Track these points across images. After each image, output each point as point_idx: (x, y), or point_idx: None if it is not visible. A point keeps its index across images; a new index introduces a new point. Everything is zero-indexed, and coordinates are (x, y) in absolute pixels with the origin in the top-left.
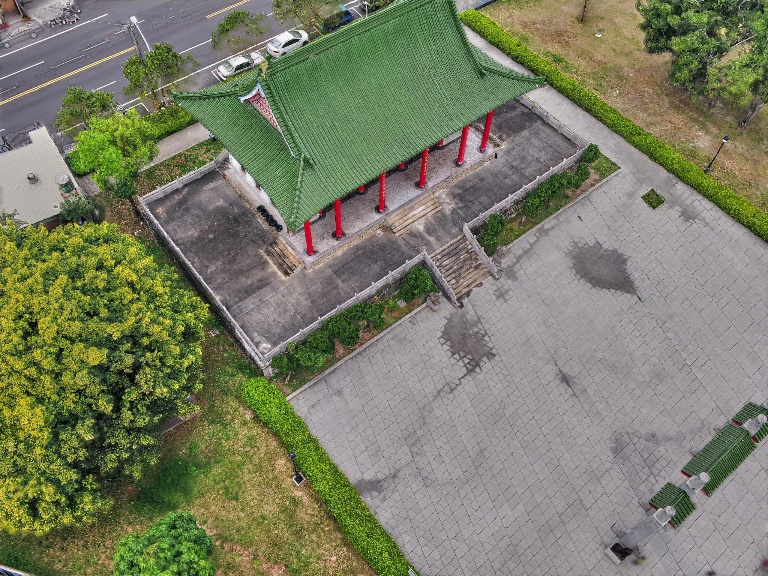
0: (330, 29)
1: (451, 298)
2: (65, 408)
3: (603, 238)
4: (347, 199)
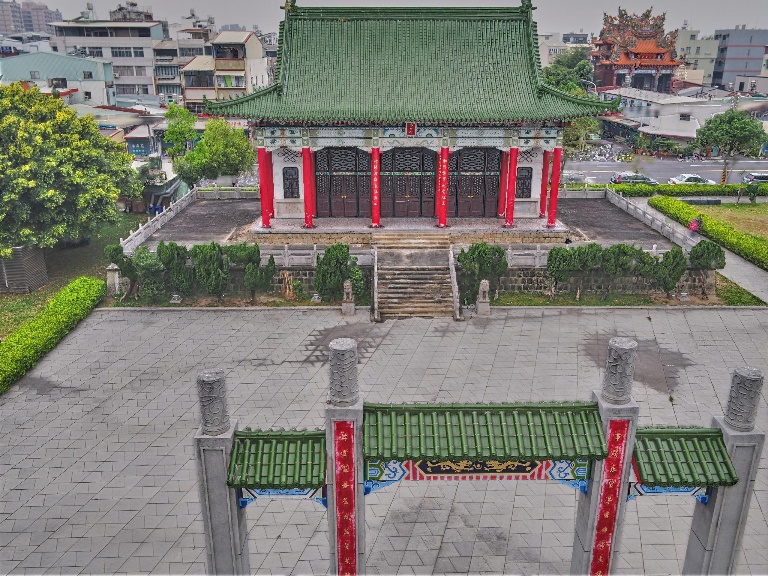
0: None
1: (374, 310)
2: None
3: (669, 340)
4: (353, 217)
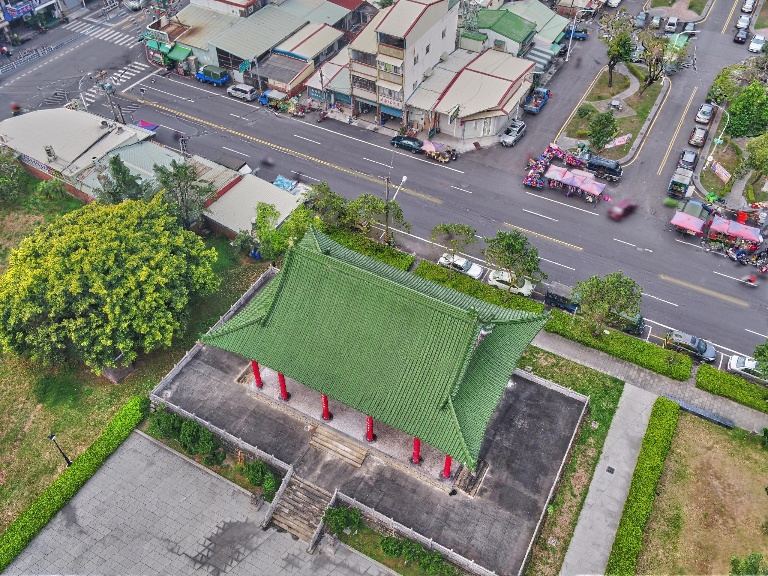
0: (554, 304)
1: None
2: (47, 295)
3: None
4: None
